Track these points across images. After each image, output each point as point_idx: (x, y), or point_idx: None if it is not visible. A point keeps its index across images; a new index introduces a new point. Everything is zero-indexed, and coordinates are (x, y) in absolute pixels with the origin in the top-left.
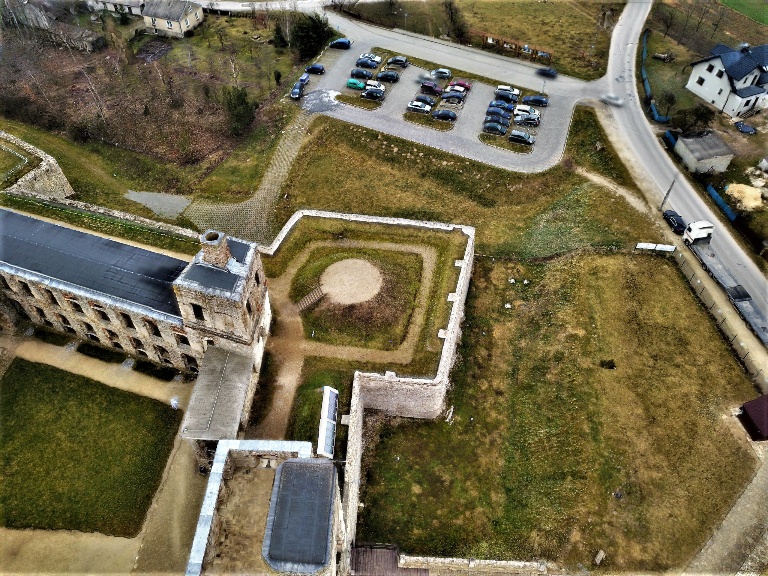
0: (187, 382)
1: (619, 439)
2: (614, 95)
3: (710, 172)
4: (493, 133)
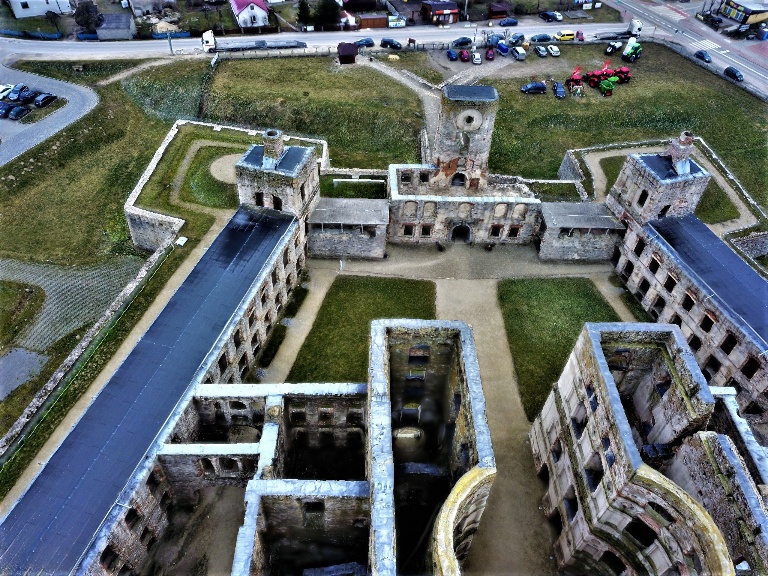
0: (309, 278)
1: (355, 98)
2: (6, 48)
3: (138, 31)
4: (24, 115)
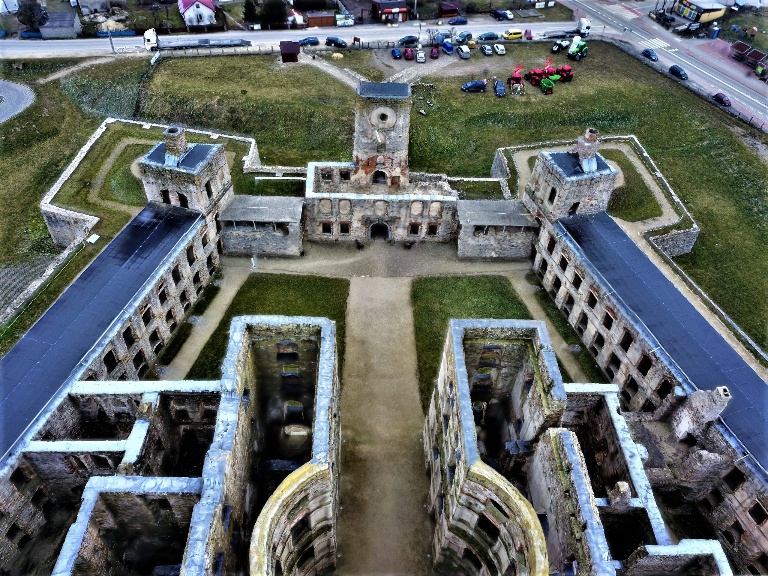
0: (223, 276)
1: (293, 97)
2: None
3: (82, 30)
4: None
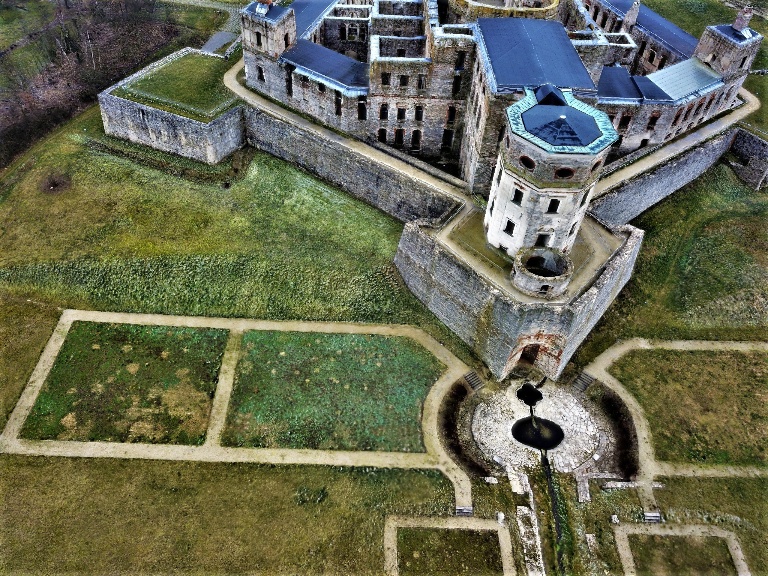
0: None
1: None
2: None
3: None
4: None
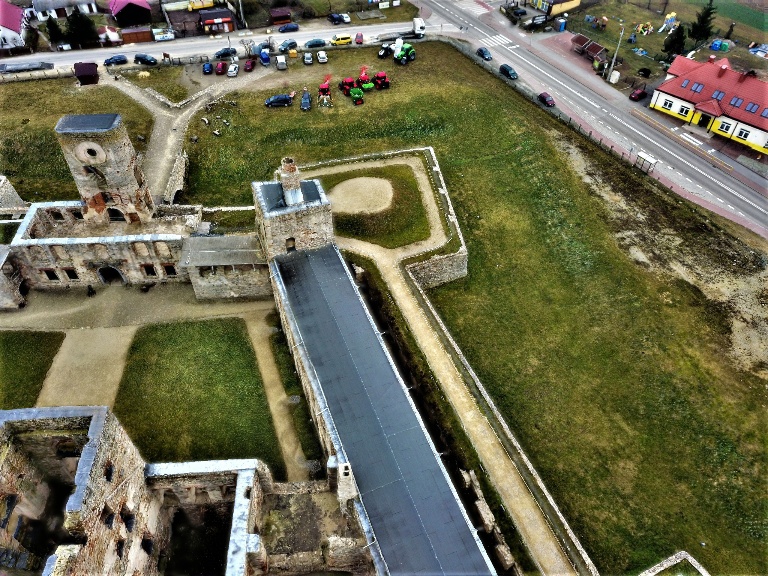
0: None
1: None
2: None
3: None
4: None
